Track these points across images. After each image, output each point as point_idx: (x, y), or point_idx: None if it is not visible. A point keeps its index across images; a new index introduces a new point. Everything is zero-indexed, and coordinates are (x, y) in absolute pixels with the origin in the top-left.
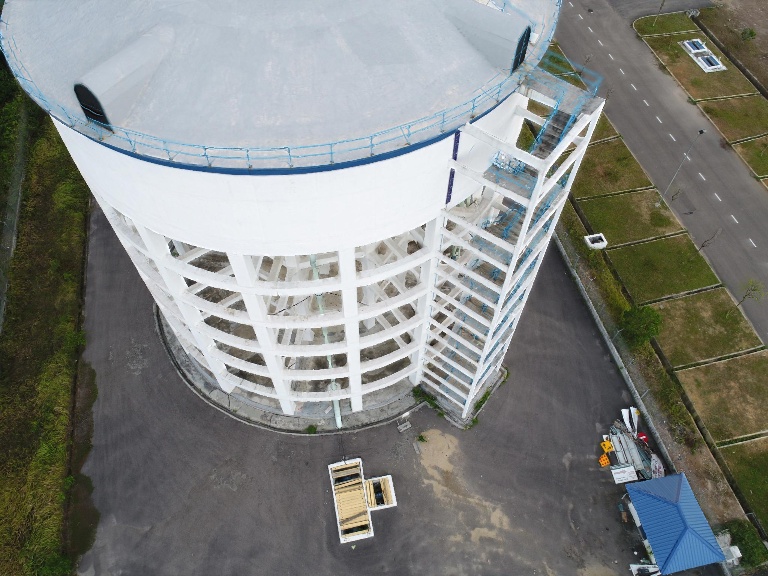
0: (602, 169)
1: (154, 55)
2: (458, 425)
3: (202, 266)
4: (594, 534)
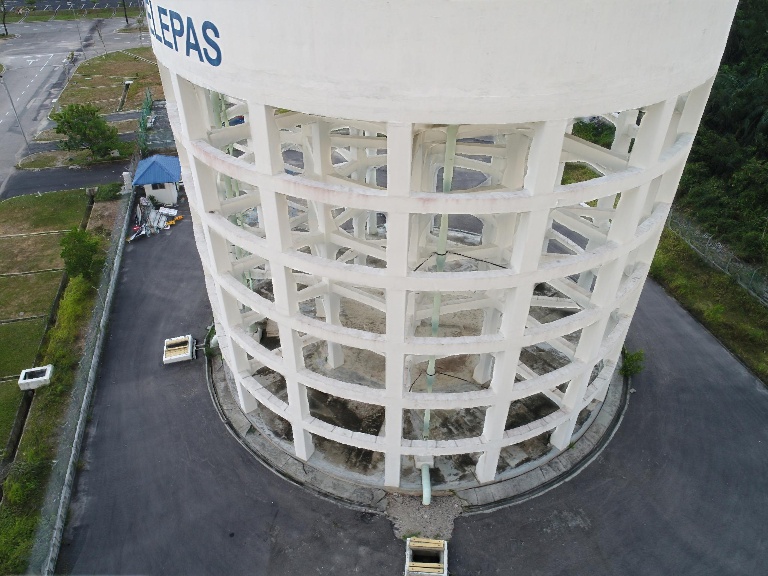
0: None
1: None
2: None
3: None
4: None
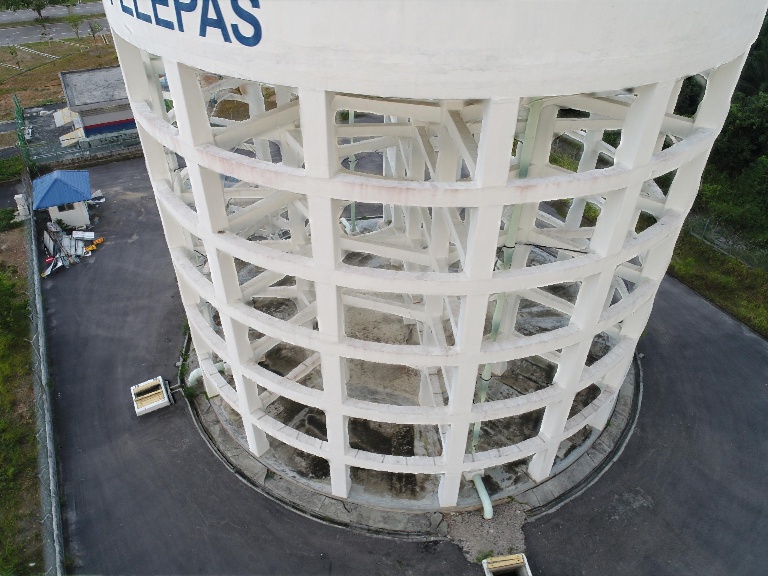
0: None
1: None
2: None
3: None
4: (127, 209)
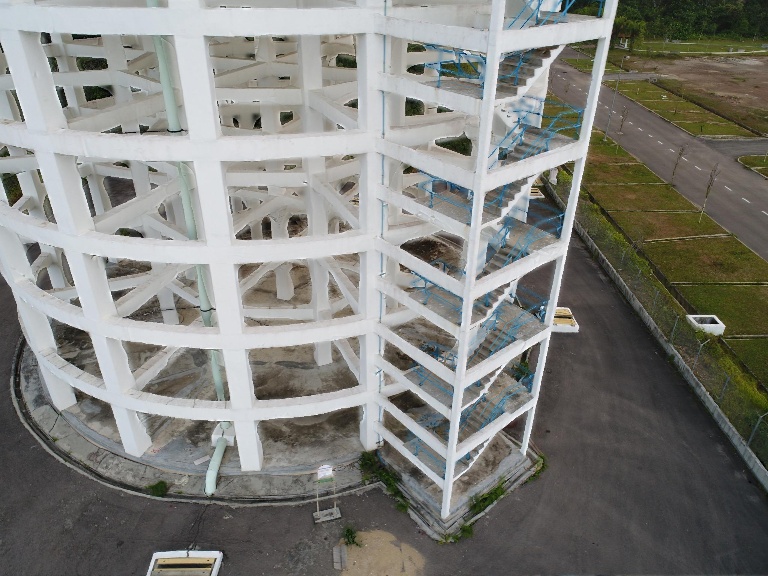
0: (709, 259)
1: None
2: (431, 532)
3: (129, 274)
4: None
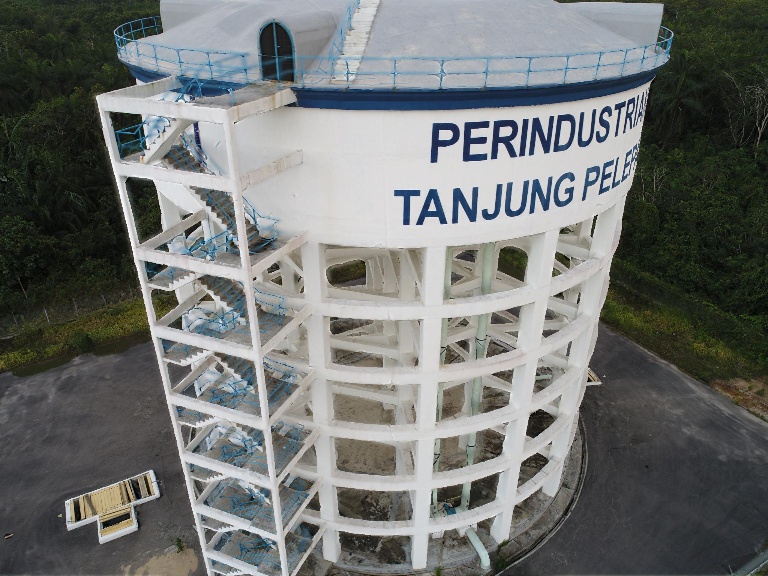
0: None
1: (211, 5)
2: None
3: None
4: None
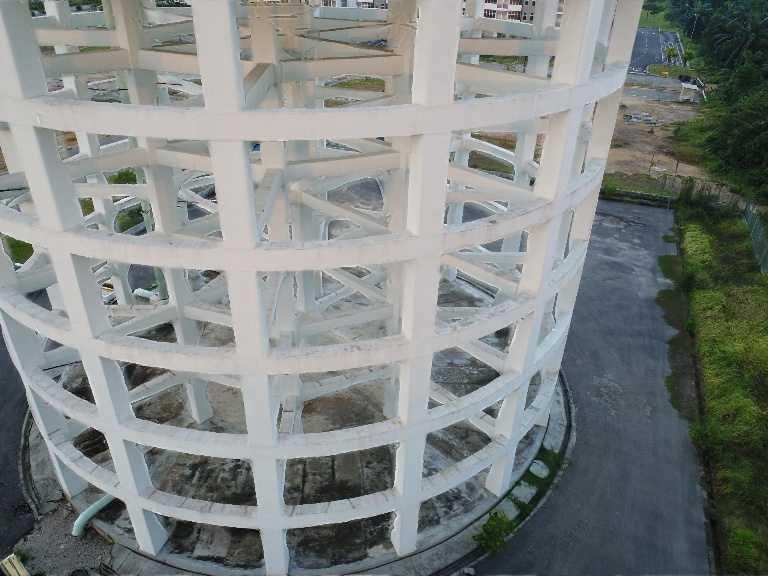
0: None
1: None
2: None
3: (475, 447)
4: None
